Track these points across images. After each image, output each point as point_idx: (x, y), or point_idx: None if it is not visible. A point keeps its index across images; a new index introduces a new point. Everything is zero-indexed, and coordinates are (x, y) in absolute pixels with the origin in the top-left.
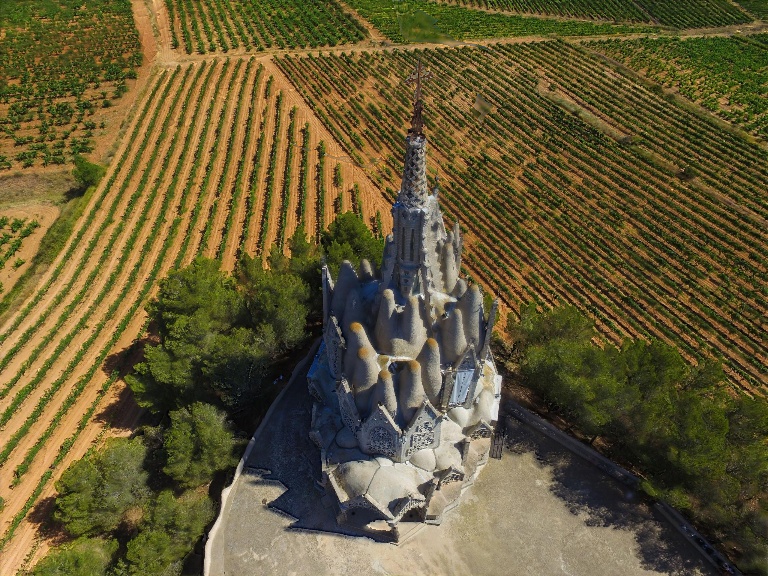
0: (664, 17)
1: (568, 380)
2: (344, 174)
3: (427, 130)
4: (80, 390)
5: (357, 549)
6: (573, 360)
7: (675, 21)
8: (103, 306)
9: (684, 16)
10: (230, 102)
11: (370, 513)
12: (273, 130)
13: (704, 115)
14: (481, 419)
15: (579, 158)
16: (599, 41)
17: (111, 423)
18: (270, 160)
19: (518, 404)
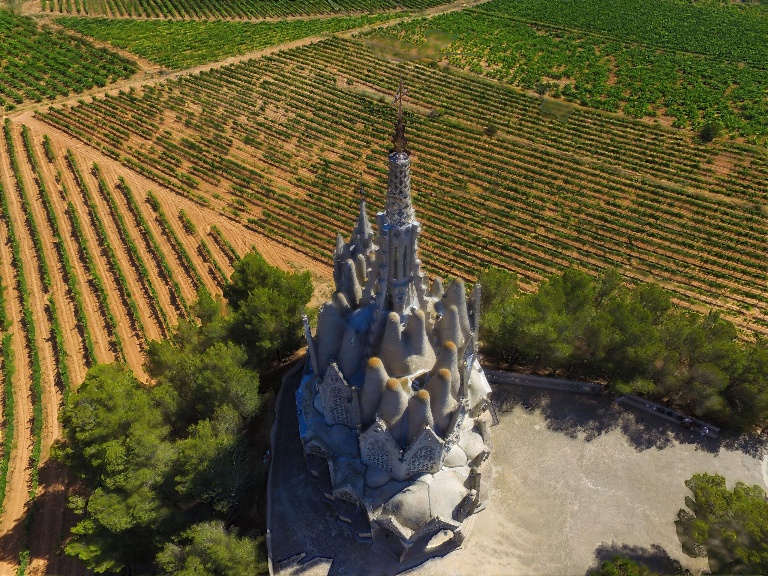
0: None
1: (531, 330)
2: (192, 219)
3: (255, 150)
4: None
5: (430, 574)
6: (528, 312)
7: (416, 4)
8: None
9: None
10: (3, 178)
11: None
12: (80, 196)
13: (477, 78)
14: (483, 396)
15: None
16: None
17: None
18: (95, 230)
19: None
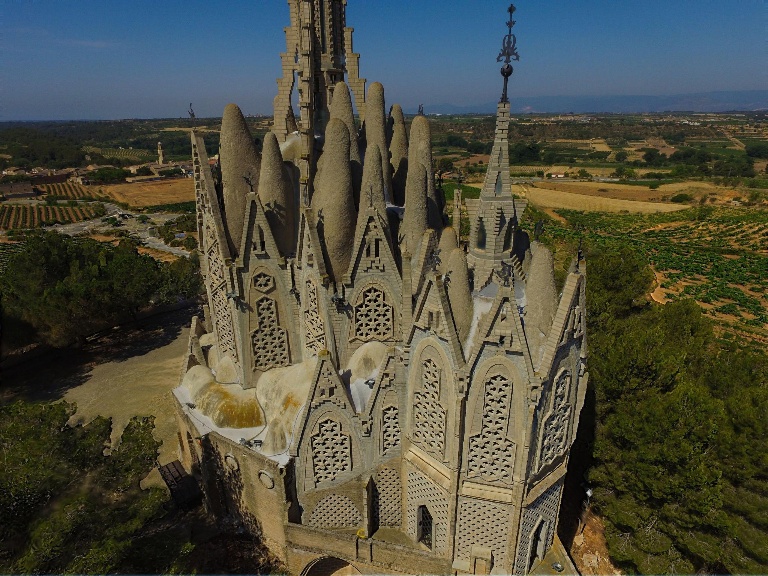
0: None
1: None
2: None
3: None
4: None
5: None
6: None
7: None
8: None
9: None
10: None
11: None
12: None
13: None
14: None
15: None
16: None
17: None
18: None
19: None
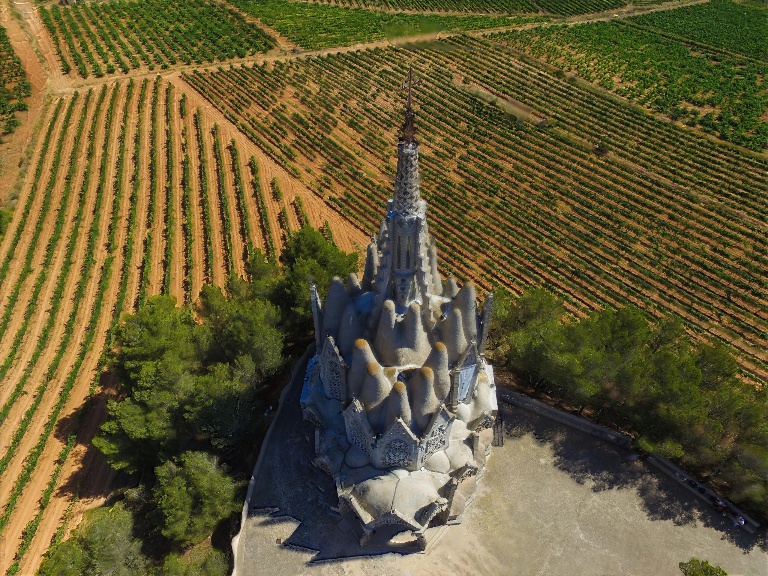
0: (551, 6)
1: (556, 358)
2: (282, 187)
3: (356, 134)
4: (33, 465)
5: (386, 567)
6: (557, 339)
7: (561, 10)
8: (40, 366)
9: (567, 4)
10: (143, 126)
11: (391, 528)
12: (197, 150)
13: (604, 94)
14: (484, 411)
15: (505, 145)
16: (499, 33)
17: (78, 494)
18: (200, 182)
19: (507, 389)
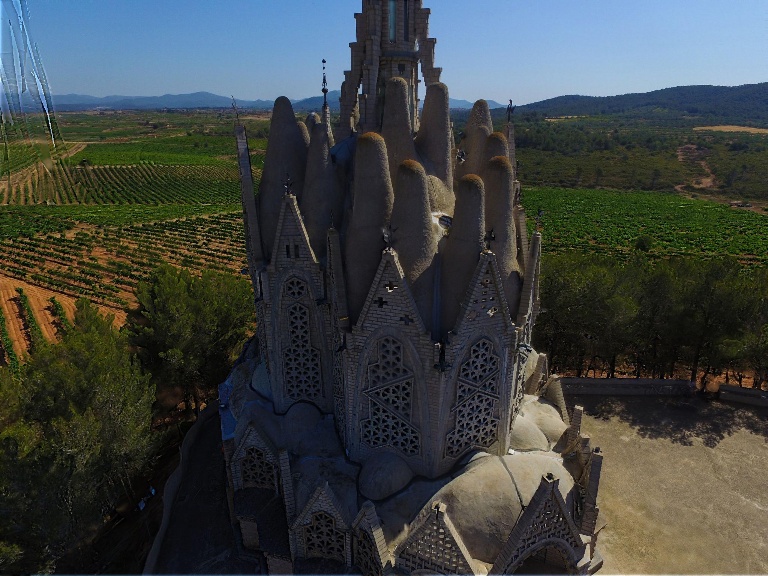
0: None
1: (575, 283)
2: None
3: None
4: None
5: None
6: None
7: None
8: None
9: None
10: None
11: None
12: None
13: None
14: None
15: None
16: None
17: None
18: None
19: None
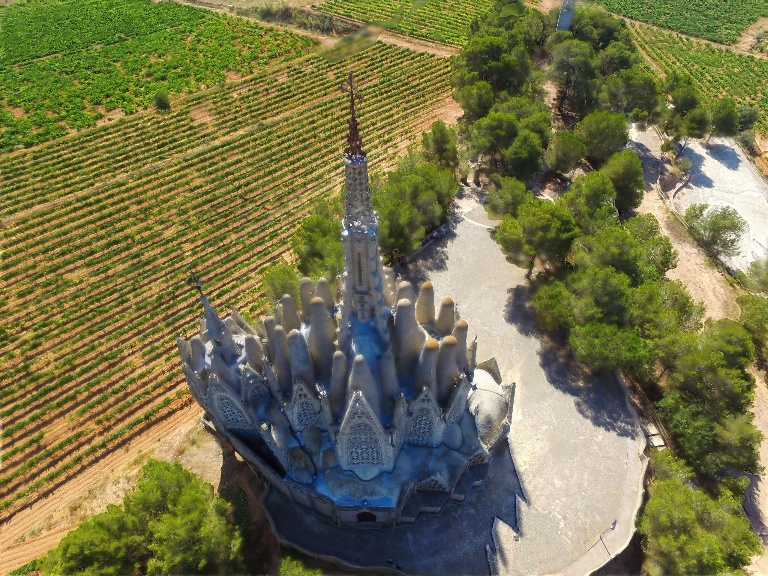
0: None
1: None
2: None
3: None
4: None
5: (515, 434)
6: None
7: None
8: None
9: None
10: None
11: None
12: None
13: None
14: None
15: None
16: None
17: None
18: None
19: None
